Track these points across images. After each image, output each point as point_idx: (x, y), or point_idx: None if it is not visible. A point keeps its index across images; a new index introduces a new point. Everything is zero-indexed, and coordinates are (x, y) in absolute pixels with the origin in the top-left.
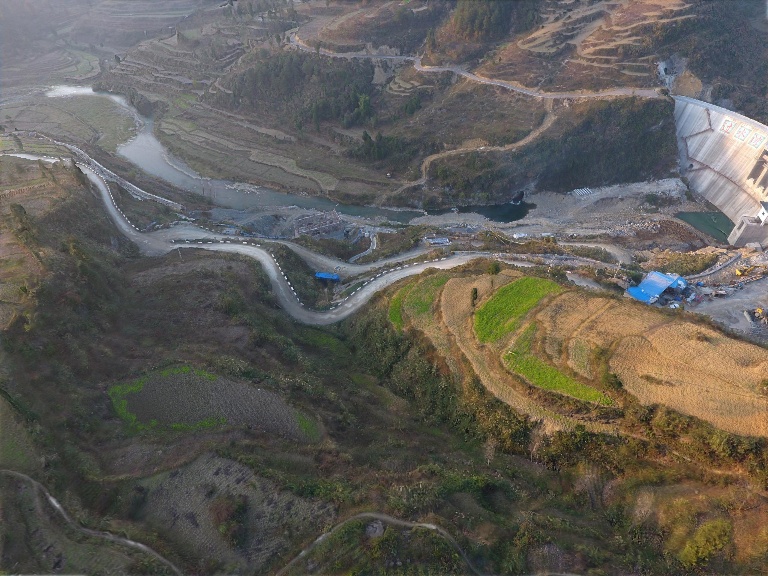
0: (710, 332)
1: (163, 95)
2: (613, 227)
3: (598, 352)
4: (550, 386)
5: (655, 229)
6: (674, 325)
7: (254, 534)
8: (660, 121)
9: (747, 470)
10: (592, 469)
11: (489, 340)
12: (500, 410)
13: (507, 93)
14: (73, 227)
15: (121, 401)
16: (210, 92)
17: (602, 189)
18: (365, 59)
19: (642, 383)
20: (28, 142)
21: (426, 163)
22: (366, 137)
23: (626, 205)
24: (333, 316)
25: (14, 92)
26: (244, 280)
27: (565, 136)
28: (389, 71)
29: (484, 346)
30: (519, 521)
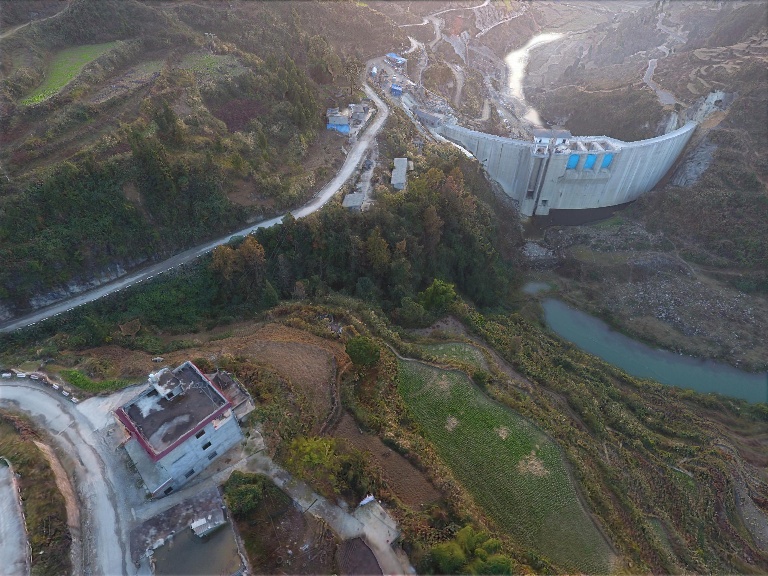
0: None
1: None
2: None
3: None
4: None
5: None
6: None
7: None
8: None
9: None
10: None
11: None
12: None
13: None
14: None
15: None
16: None
17: None
18: (665, 33)
19: None
20: (515, 5)
21: None
22: None
23: None
24: None
25: (593, 5)
26: (393, 13)
27: (601, 98)
28: None
29: None
30: None
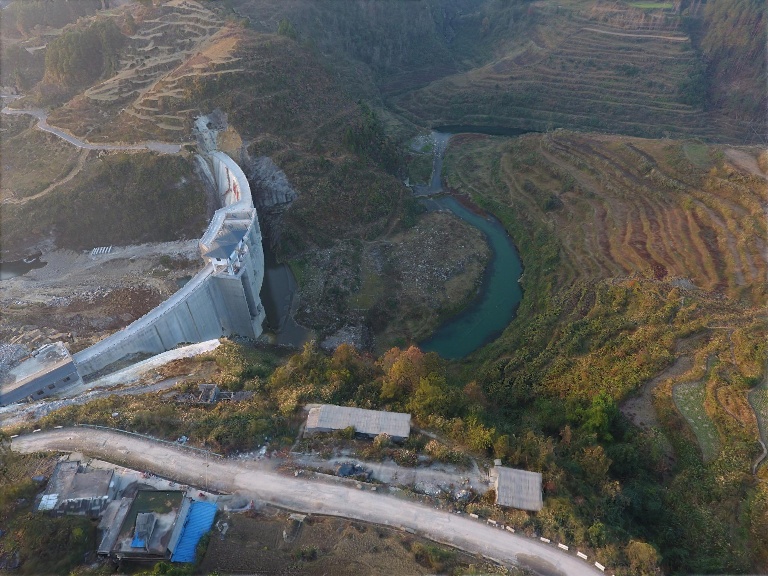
0: None
1: None
2: None
3: None
4: None
5: (96, 299)
6: None
7: None
8: (180, 178)
9: None
10: None
11: None
12: None
13: (56, 141)
14: None
15: None
16: None
17: (126, 248)
18: None
19: None
20: None
21: None
22: None
23: (137, 267)
24: None
25: None
26: None
27: (77, 191)
28: None
29: None
30: None
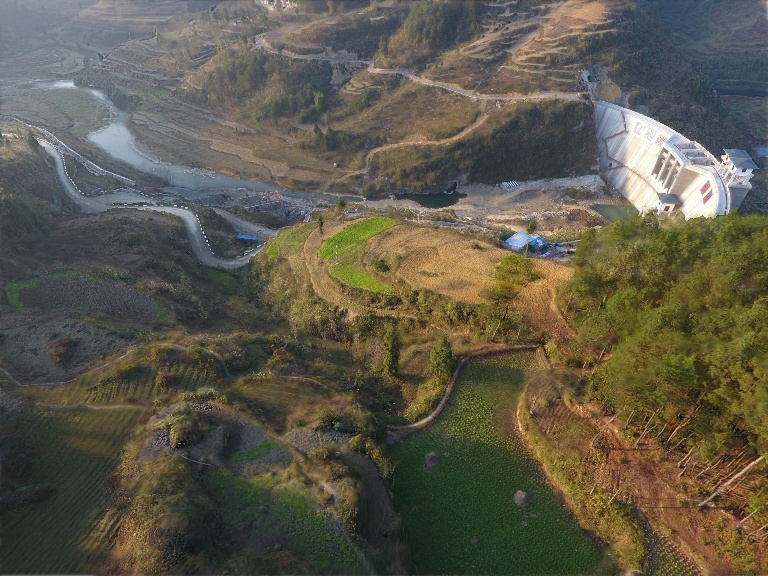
0: (486, 244)
1: (139, 90)
2: (530, 214)
3: (396, 258)
4: (356, 283)
5: (564, 215)
6: (463, 241)
7: (77, 358)
8: (580, 122)
9: (468, 328)
10: (374, 342)
11: (327, 258)
12: (319, 305)
13: (447, 94)
14: (17, 183)
15: (14, 294)
16: (181, 88)
17: (528, 183)
18: (324, 61)
19: (418, 276)
20: (1, 124)
21: (370, 155)
22: (317, 130)
23: (548, 197)
24: (237, 263)
25: None
26: (161, 229)
27: (494, 133)
28: (346, 73)
29: (323, 262)
30: (273, 347)
